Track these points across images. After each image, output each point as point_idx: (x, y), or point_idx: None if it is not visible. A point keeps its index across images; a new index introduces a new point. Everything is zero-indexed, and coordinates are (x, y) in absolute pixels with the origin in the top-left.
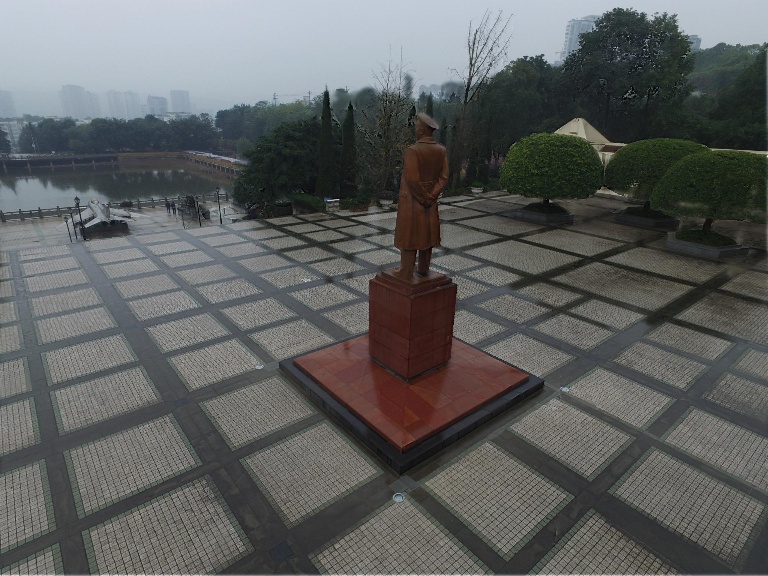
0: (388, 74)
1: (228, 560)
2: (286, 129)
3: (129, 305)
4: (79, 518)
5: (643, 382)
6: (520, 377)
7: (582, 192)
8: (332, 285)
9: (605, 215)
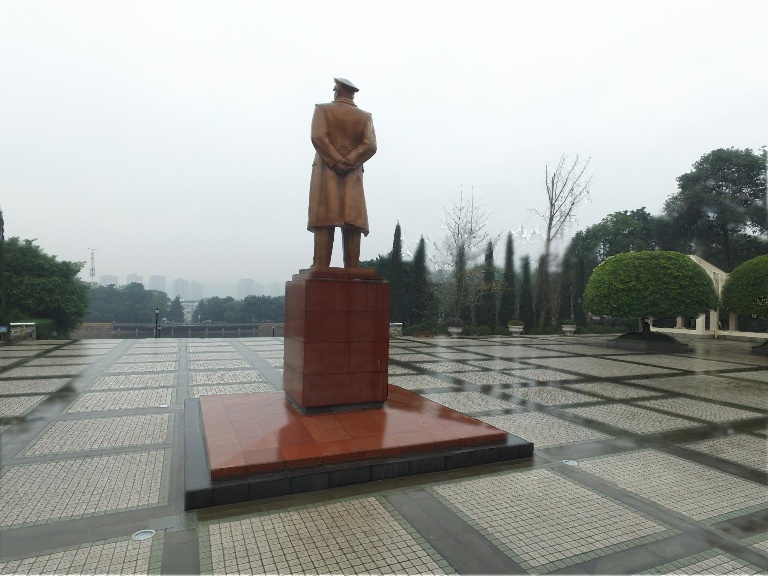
0: (460, 210)
1: None
2: (362, 263)
3: (112, 365)
4: None
5: (732, 471)
6: (489, 432)
7: (687, 309)
8: None
9: (736, 350)
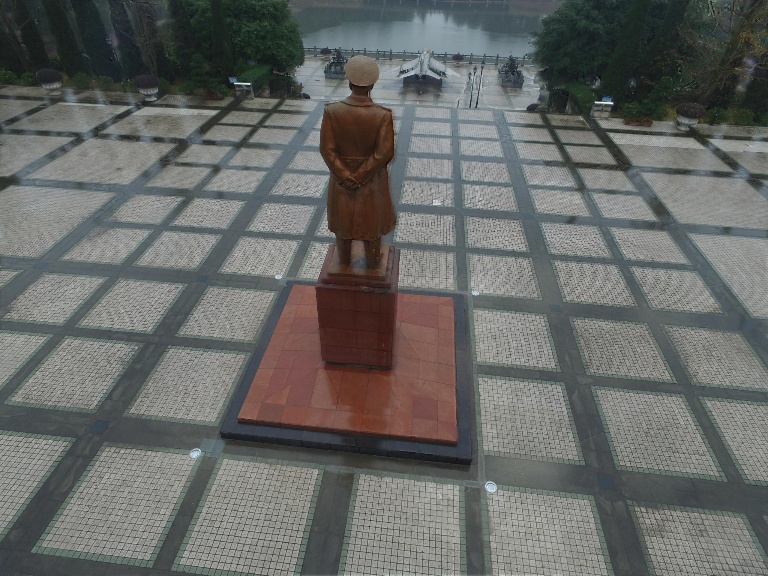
0: None
1: (79, 408)
2: None
3: (282, 176)
4: (75, 326)
5: (621, 567)
6: (442, 435)
7: None
8: (450, 219)
9: None
